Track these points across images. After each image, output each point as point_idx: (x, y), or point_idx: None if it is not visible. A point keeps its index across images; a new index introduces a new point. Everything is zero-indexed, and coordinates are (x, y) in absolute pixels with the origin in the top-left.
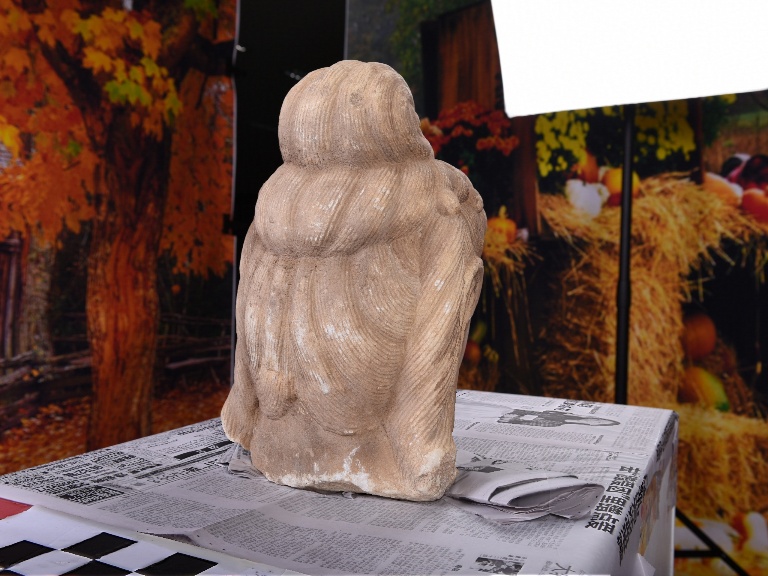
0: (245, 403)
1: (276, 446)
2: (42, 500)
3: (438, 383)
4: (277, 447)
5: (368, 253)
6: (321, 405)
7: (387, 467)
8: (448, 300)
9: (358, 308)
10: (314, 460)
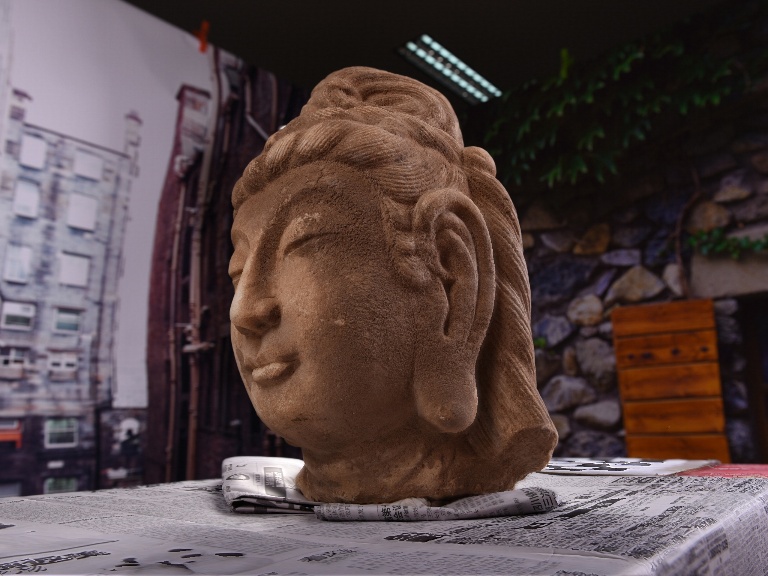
0: None
1: None
2: None
3: None
4: None
5: None
6: None
7: None
8: None
9: None
10: None
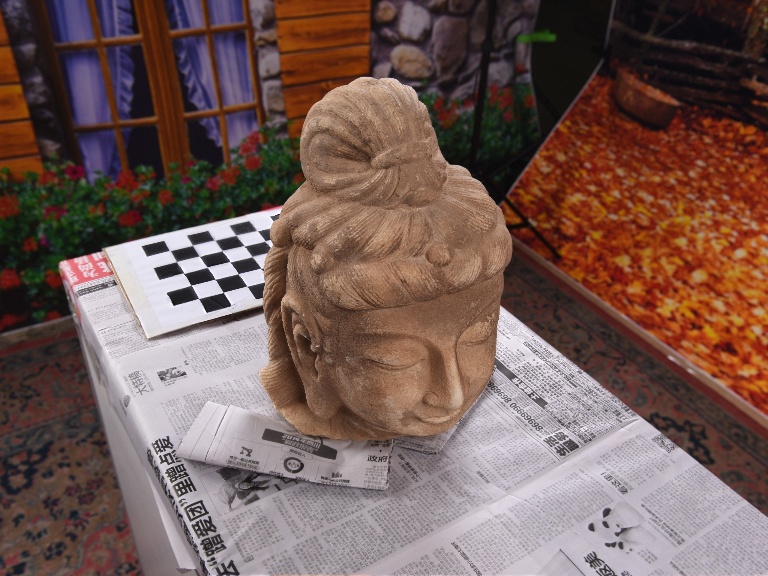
0: None
1: None
2: None
3: None
4: None
5: None
6: None
7: None
8: None
9: None
10: None
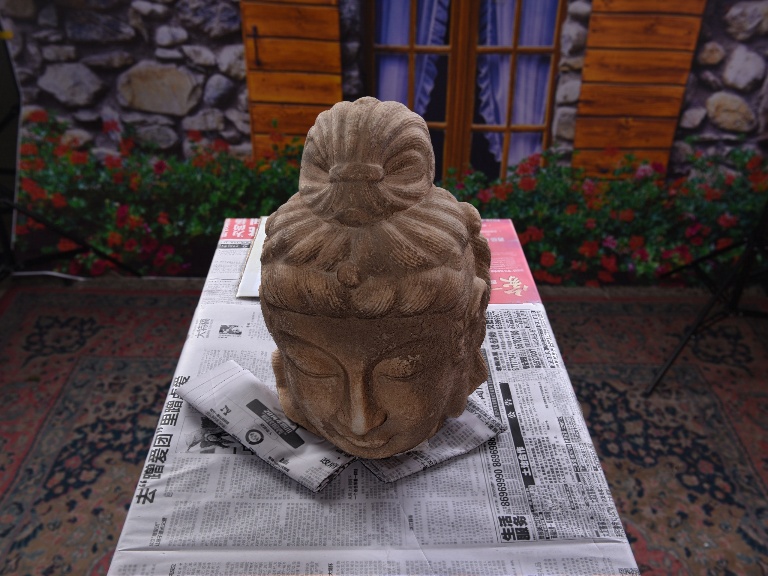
0: None
1: None
2: None
3: None
4: None
5: None
6: None
7: None
8: None
9: None
10: None
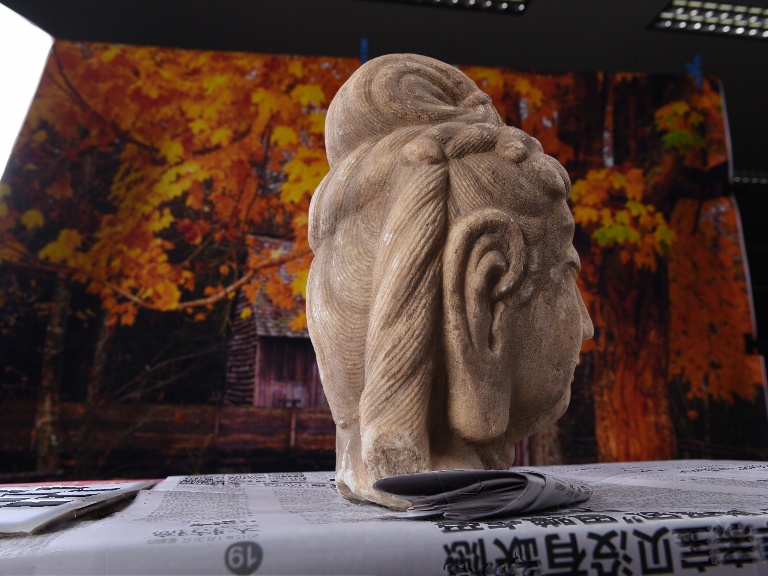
0: None
1: None
2: None
3: (387, 352)
4: None
5: None
6: None
7: None
8: (397, 254)
9: (329, 283)
10: None
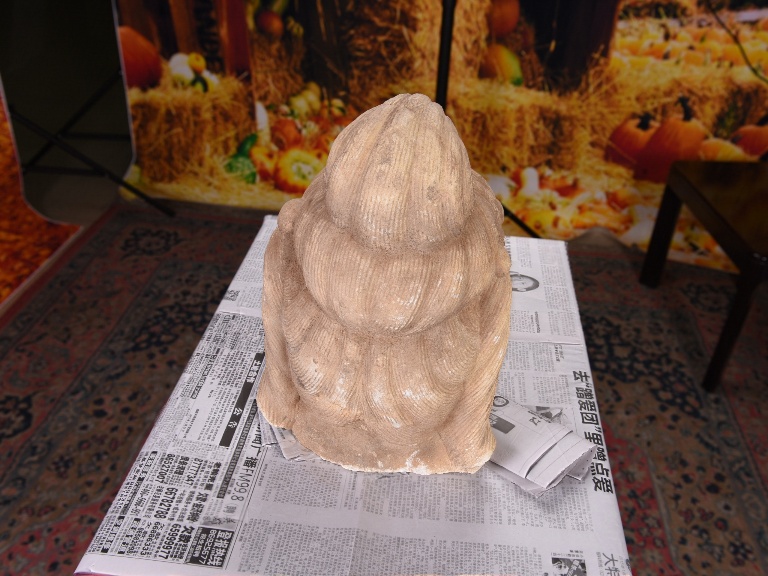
0: (286, 400)
1: (334, 444)
2: (181, 574)
3: (488, 405)
4: (335, 445)
5: (441, 330)
6: (390, 433)
7: (441, 459)
8: (502, 348)
9: (432, 374)
10: (377, 459)
